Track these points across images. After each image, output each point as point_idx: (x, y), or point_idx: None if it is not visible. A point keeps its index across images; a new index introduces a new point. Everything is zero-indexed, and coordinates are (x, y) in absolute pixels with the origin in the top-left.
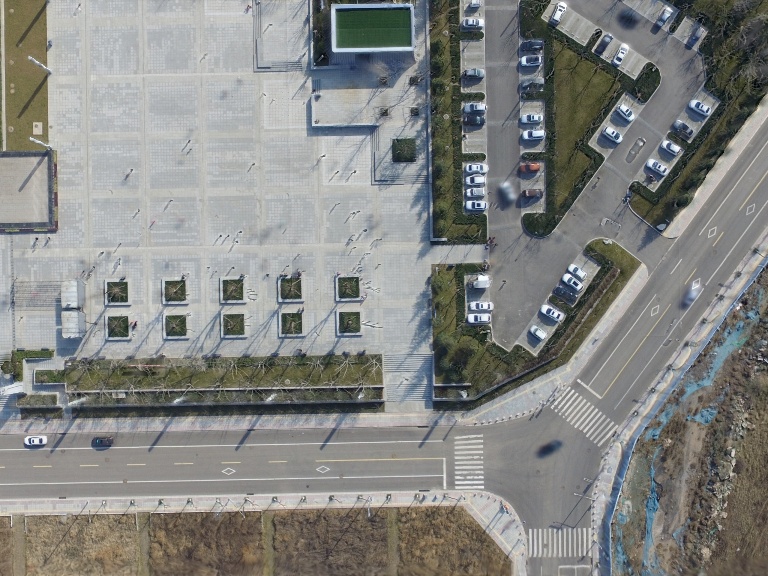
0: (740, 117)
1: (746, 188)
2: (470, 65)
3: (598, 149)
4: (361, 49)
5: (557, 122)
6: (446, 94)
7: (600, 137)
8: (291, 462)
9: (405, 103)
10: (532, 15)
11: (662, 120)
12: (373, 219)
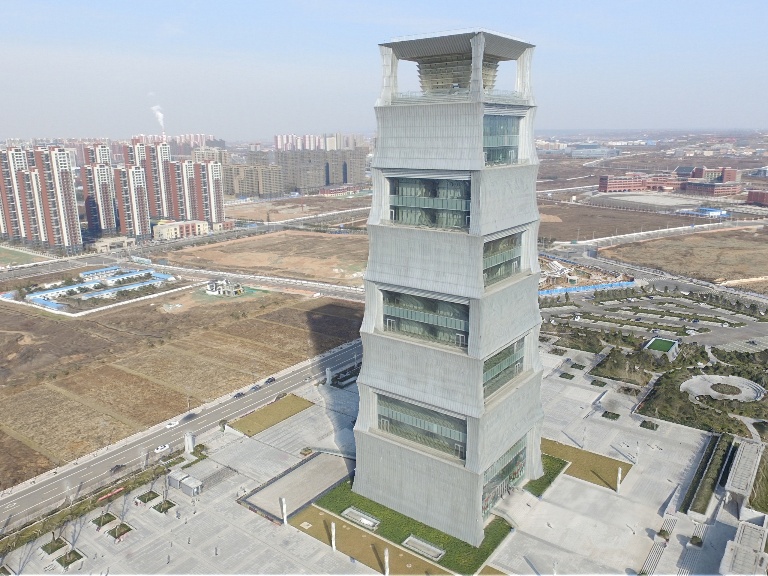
0: None
1: None
2: None
3: None
4: None
5: None
6: None
7: None
8: None
9: None
10: None
11: None
12: None
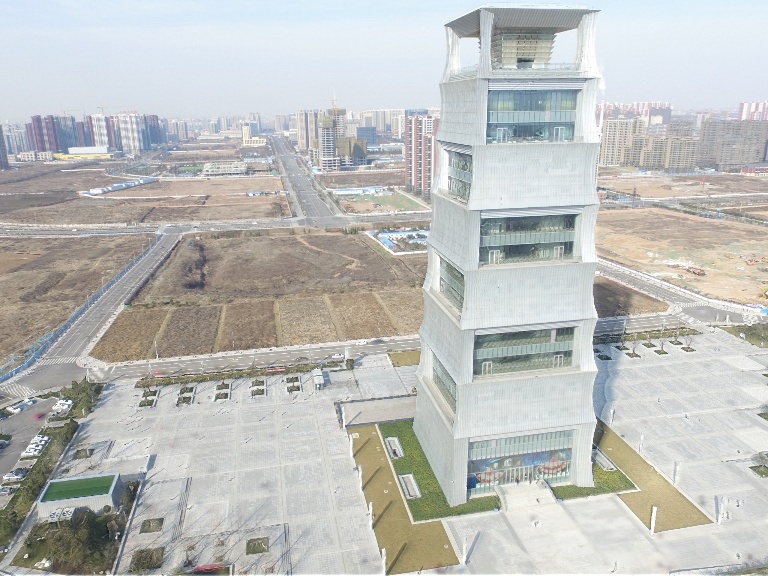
0: None
1: None
2: (4, 499)
3: None
4: (96, 476)
5: None
6: None
7: None
8: None
9: (72, 475)
10: None
11: None
12: None
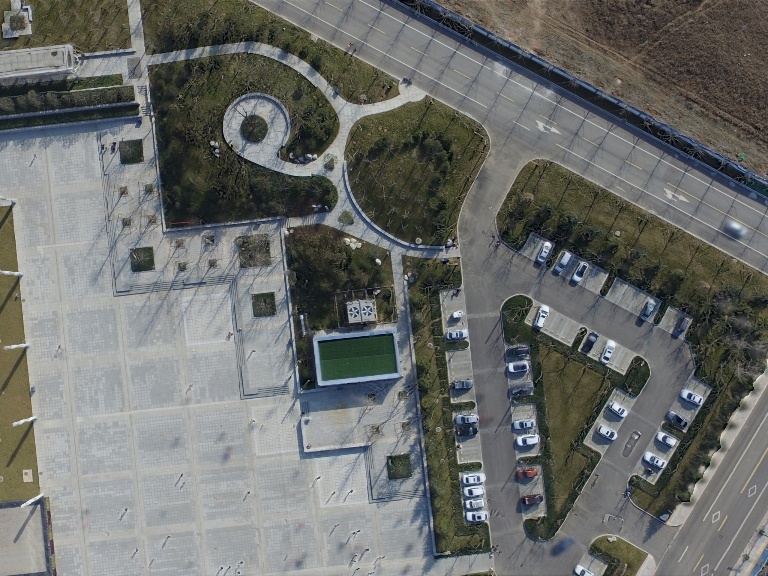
0: (733, 406)
1: (746, 470)
2: (458, 375)
3: (594, 446)
4: (347, 380)
5: (550, 425)
6: (436, 407)
7: (595, 434)
8: None
9: (396, 418)
10: (515, 322)
11: (655, 411)
12: (374, 537)
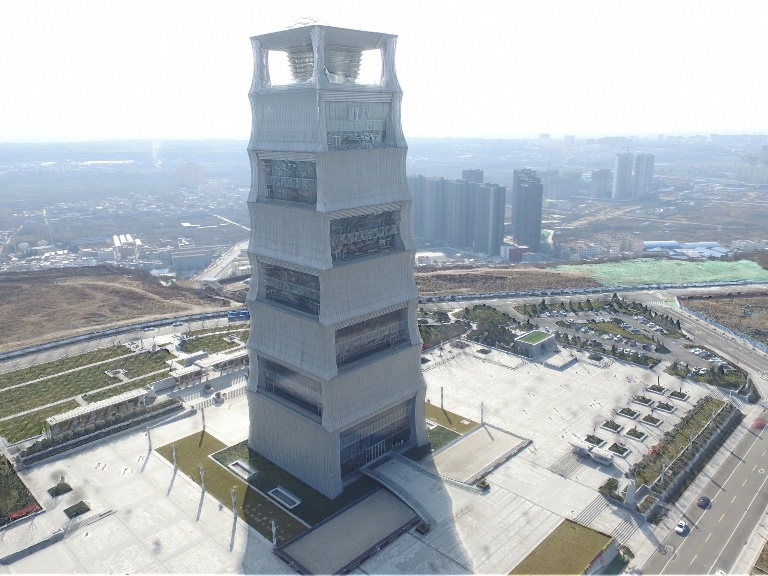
0: None
1: None
2: None
3: None
4: None
5: None
6: None
7: (633, 332)
8: (767, 450)
9: None
10: None
11: None
12: None
